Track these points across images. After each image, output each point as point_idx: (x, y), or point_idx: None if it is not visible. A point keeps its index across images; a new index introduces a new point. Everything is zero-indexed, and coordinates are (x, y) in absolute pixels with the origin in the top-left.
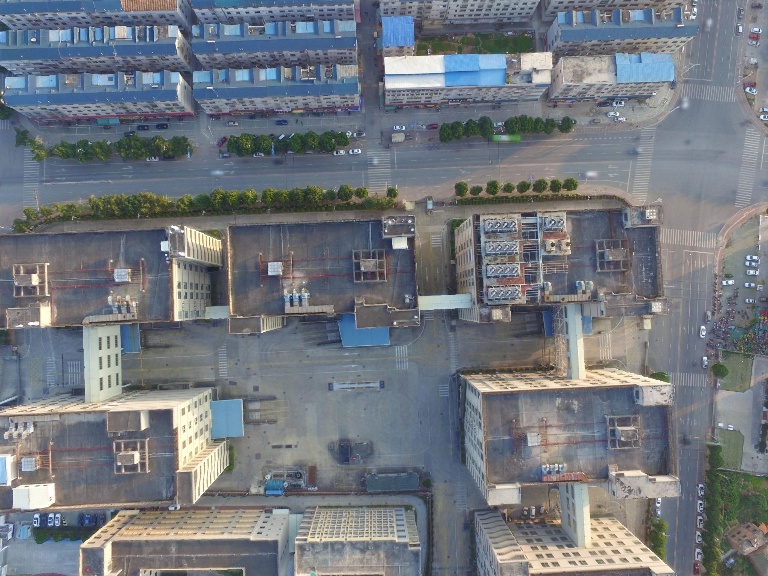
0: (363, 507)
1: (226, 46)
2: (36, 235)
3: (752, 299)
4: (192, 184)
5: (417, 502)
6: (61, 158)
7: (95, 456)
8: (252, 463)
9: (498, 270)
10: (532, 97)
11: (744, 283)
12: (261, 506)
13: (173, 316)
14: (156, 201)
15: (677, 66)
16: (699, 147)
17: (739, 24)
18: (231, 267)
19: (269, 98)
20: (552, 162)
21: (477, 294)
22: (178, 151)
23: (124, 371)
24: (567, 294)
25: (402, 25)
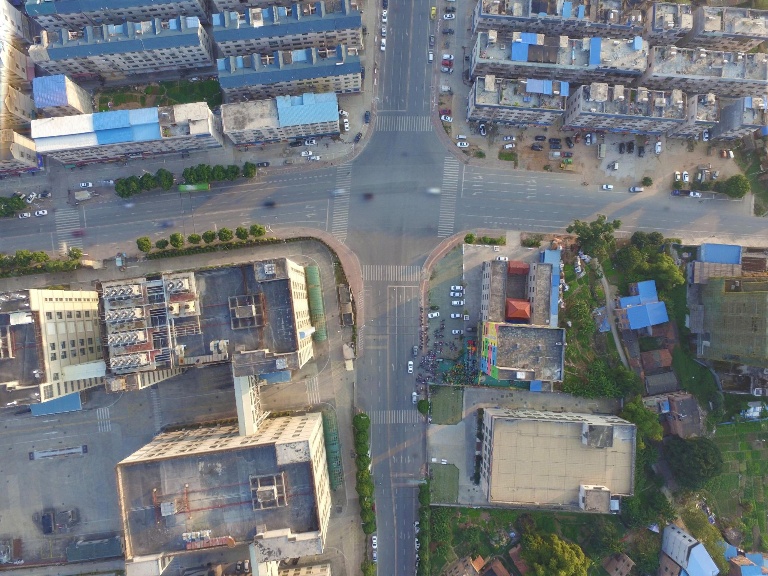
0: None
1: None
2: None
3: (458, 330)
4: None
5: None
6: None
7: None
8: None
9: (116, 339)
10: (211, 145)
11: (450, 314)
12: None
13: None
14: None
15: (371, 99)
16: (397, 180)
17: (430, 52)
18: None
19: None
20: (247, 207)
21: None
22: None
23: None
24: (203, 355)
25: (53, 85)
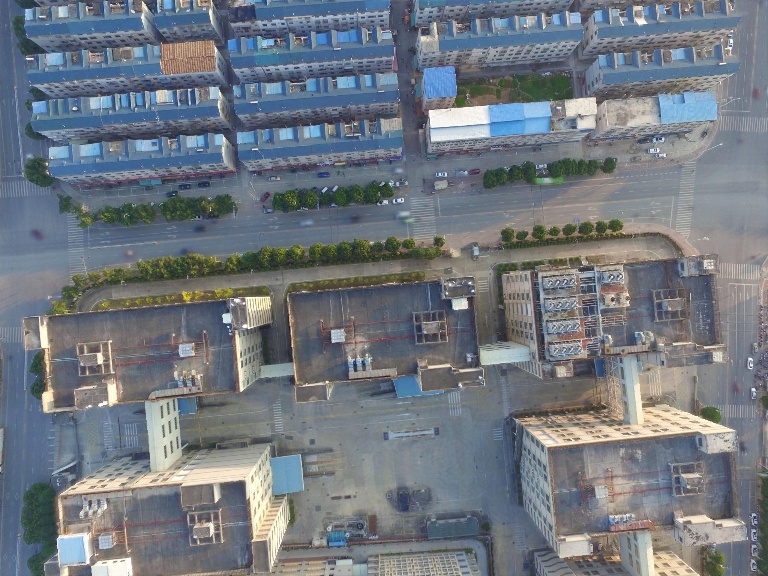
0: (424, 553)
1: (269, 106)
2: (97, 313)
3: None
4: (237, 241)
5: (476, 545)
6: (106, 223)
7: (169, 529)
8: (312, 515)
9: (560, 327)
10: (574, 139)
11: None
12: (324, 557)
13: (239, 387)
14: (205, 262)
15: (715, 98)
16: (740, 179)
17: None
18: (293, 335)
19: (314, 155)
20: (595, 202)
21: (538, 350)
22: (223, 210)
23: (181, 431)
24: (627, 345)
25: (444, 76)
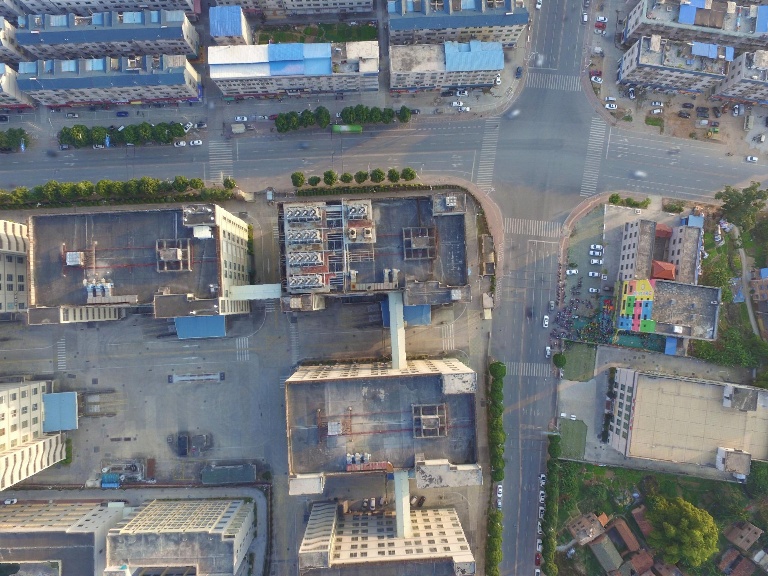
0: (202, 500)
1: (51, 37)
2: None
3: (595, 288)
4: (32, 176)
5: (257, 494)
6: None
7: None
8: (90, 456)
9: (297, 258)
10: (369, 87)
11: (588, 272)
12: (99, 499)
13: None
14: None
15: (523, 55)
16: (544, 136)
17: (585, 13)
18: (34, 257)
19: (97, 89)
20: (395, 152)
21: (281, 283)
22: (13, 143)
23: None
24: (374, 282)
25: (229, 15)
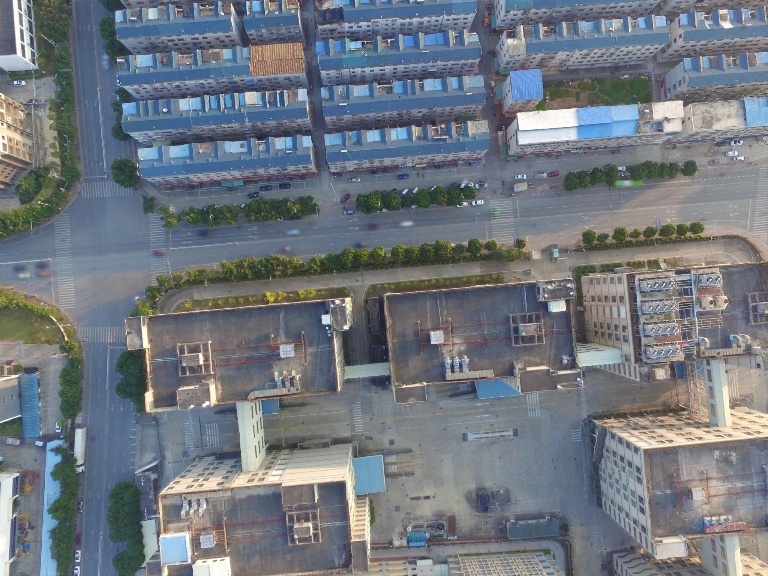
0: (503, 553)
1: (357, 108)
2: (196, 313)
3: None
4: (317, 242)
5: (555, 546)
6: (191, 224)
7: (267, 528)
8: (392, 515)
9: (659, 330)
10: (655, 142)
11: None
12: (403, 557)
13: (338, 388)
14: (288, 263)
15: None
16: None
17: None
18: (391, 336)
19: (400, 157)
20: (673, 204)
21: (635, 353)
22: (306, 211)
23: None
24: (722, 348)
25: (531, 79)
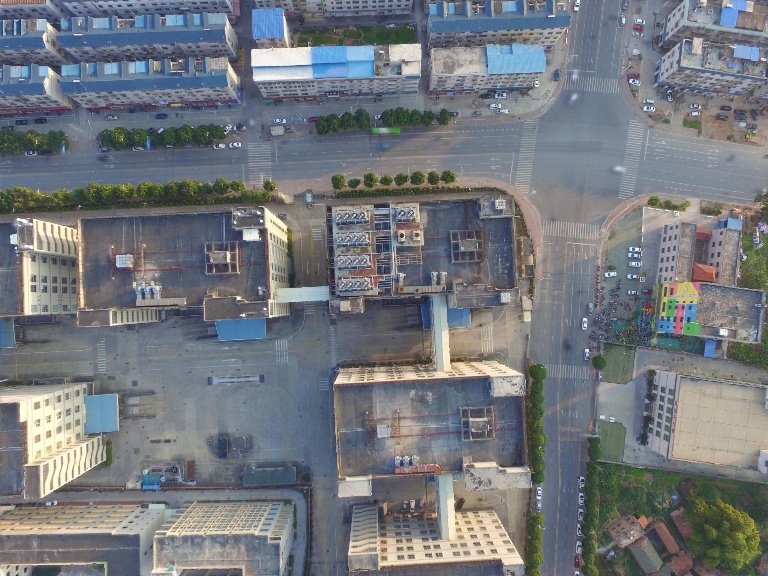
0: (242, 501)
1: (94, 39)
2: None
3: (634, 291)
4: (71, 178)
5: (297, 496)
6: None
7: None
8: (131, 458)
9: (347, 261)
10: (409, 89)
11: (627, 275)
12: (139, 501)
13: (23, 309)
14: (30, 195)
15: (561, 58)
16: (582, 139)
17: (623, 15)
18: (83, 260)
19: (139, 91)
20: (434, 154)
21: (329, 286)
22: (54, 145)
23: (2, 366)
24: (421, 285)
25: (272, 17)
